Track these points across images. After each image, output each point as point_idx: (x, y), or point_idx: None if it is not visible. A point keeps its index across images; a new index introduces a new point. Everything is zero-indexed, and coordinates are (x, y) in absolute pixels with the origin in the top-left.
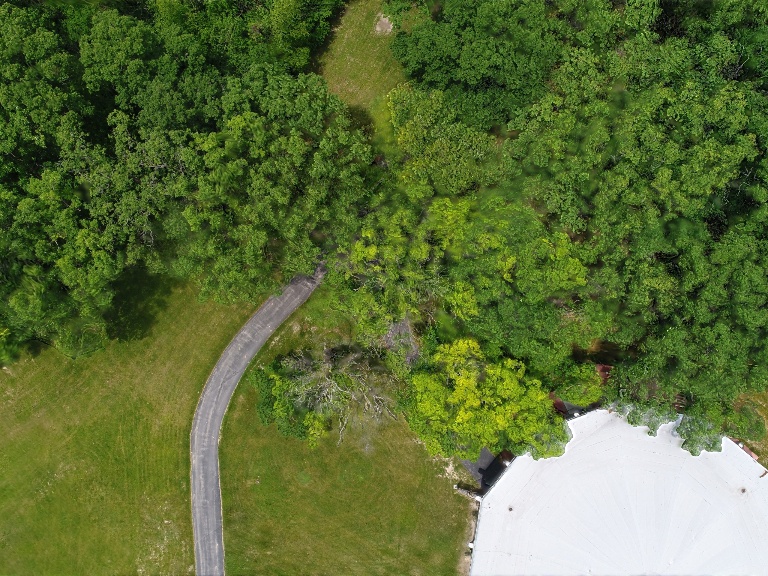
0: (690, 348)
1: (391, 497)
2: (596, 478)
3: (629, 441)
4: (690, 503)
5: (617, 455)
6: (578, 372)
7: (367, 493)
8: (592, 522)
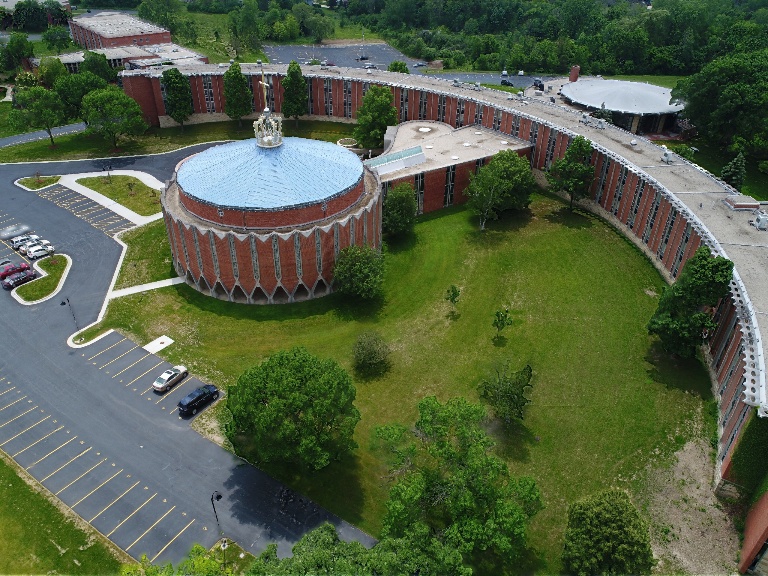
0: None
1: None
2: None
3: None
4: (644, 105)
5: None
6: None
7: None
8: None
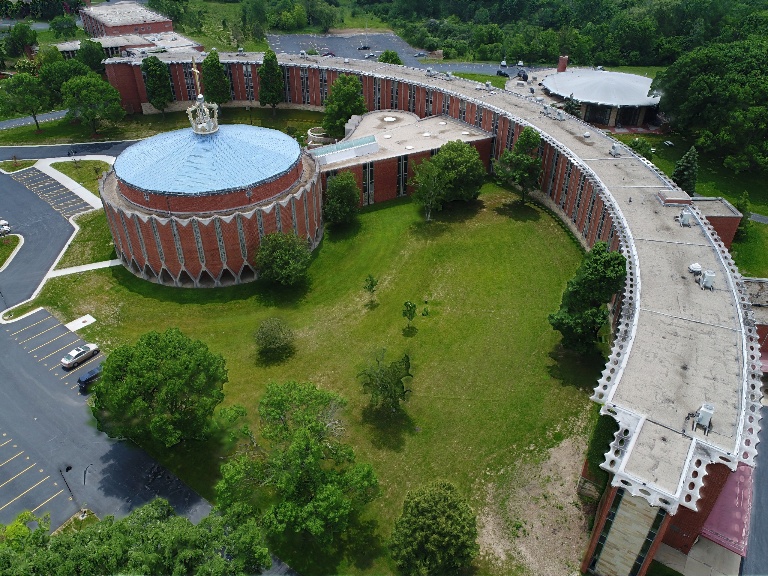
0: None
1: None
2: None
3: None
4: (624, 97)
5: None
6: None
7: None
8: None
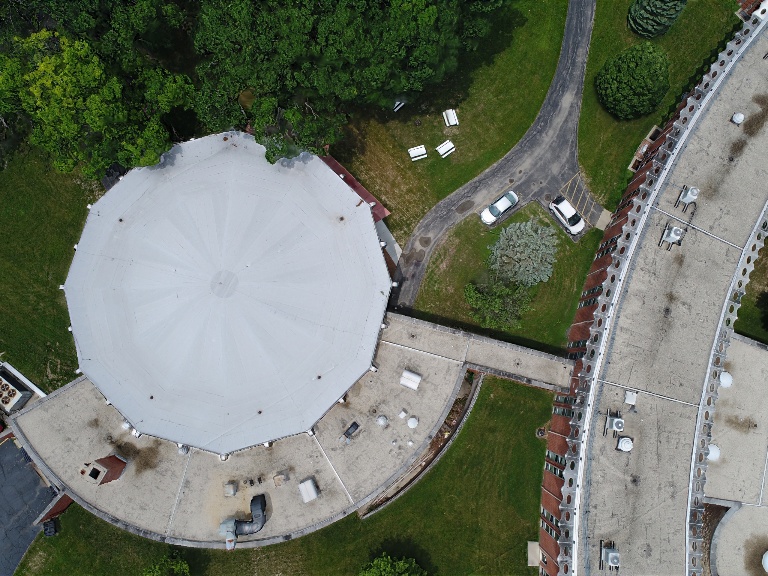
0: (228, 29)
1: (45, 229)
2: (203, 197)
3: (240, 167)
4: (287, 224)
5: (227, 179)
6: (170, 79)
7: (25, 226)
8: (188, 231)
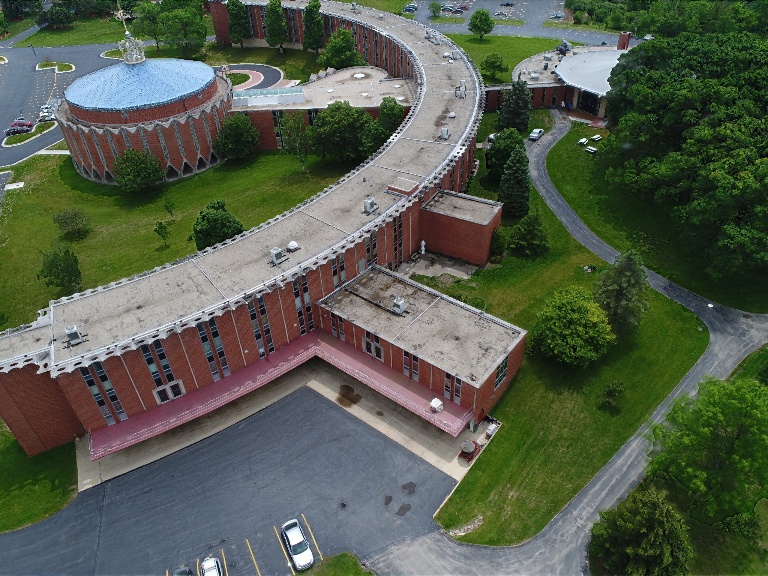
0: None
1: None
2: None
3: None
4: None
5: None
6: None
7: None
8: None
